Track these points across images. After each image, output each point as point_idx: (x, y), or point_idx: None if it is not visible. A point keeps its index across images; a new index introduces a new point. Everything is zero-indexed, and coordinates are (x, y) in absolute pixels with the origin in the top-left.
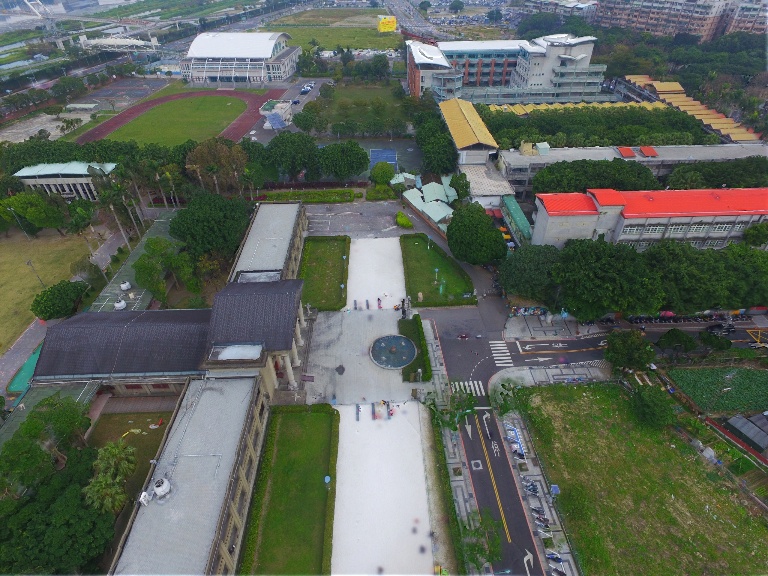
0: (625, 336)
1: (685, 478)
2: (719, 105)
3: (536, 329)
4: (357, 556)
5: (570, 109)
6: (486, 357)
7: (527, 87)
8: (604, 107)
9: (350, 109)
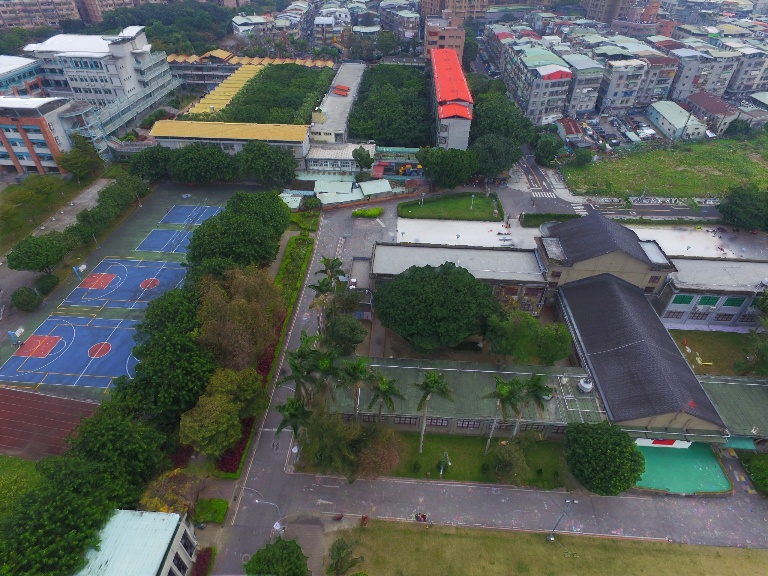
0: (545, 146)
1: (609, 167)
2: (277, 53)
3: (518, 180)
4: (709, 252)
5: (248, 87)
6: (550, 200)
7: (127, 96)
8: (254, 77)
9: (17, 213)
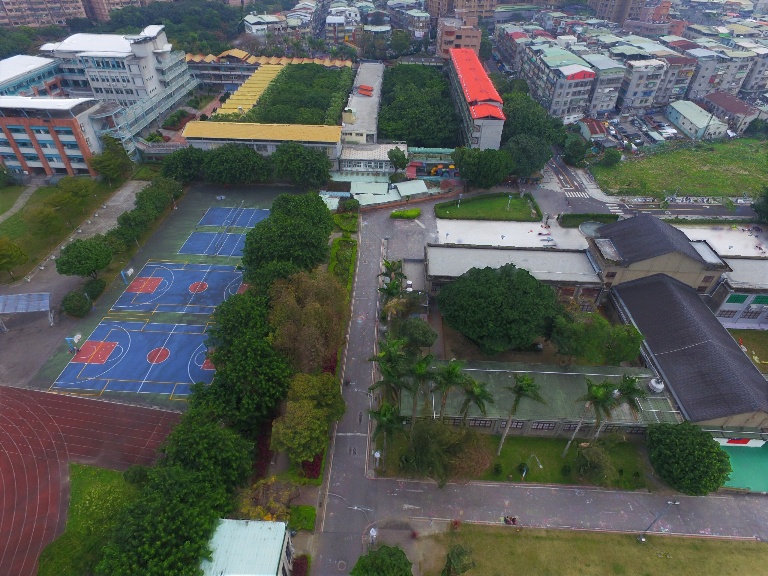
0: (575, 146)
1: None
2: (295, 53)
3: (550, 180)
4: (748, 251)
5: (273, 87)
6: (584, 200)
7: (149, 96)
8: (277, 77)
9: (56, 216)
